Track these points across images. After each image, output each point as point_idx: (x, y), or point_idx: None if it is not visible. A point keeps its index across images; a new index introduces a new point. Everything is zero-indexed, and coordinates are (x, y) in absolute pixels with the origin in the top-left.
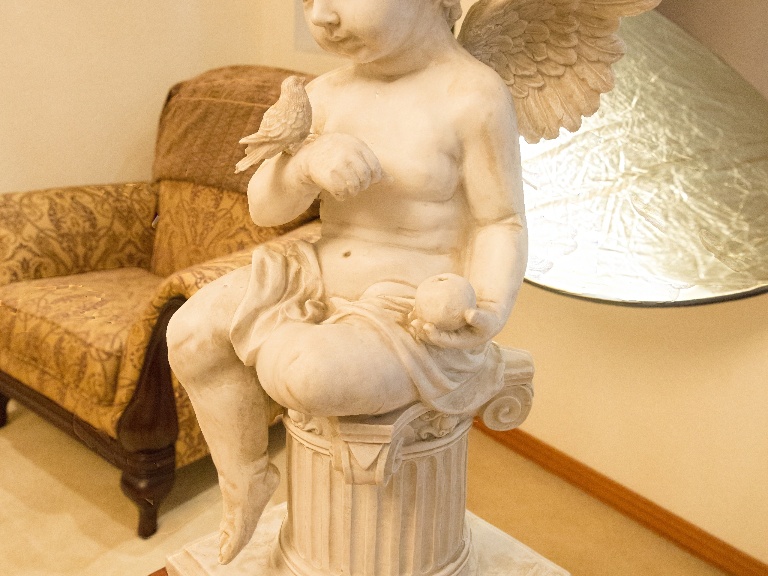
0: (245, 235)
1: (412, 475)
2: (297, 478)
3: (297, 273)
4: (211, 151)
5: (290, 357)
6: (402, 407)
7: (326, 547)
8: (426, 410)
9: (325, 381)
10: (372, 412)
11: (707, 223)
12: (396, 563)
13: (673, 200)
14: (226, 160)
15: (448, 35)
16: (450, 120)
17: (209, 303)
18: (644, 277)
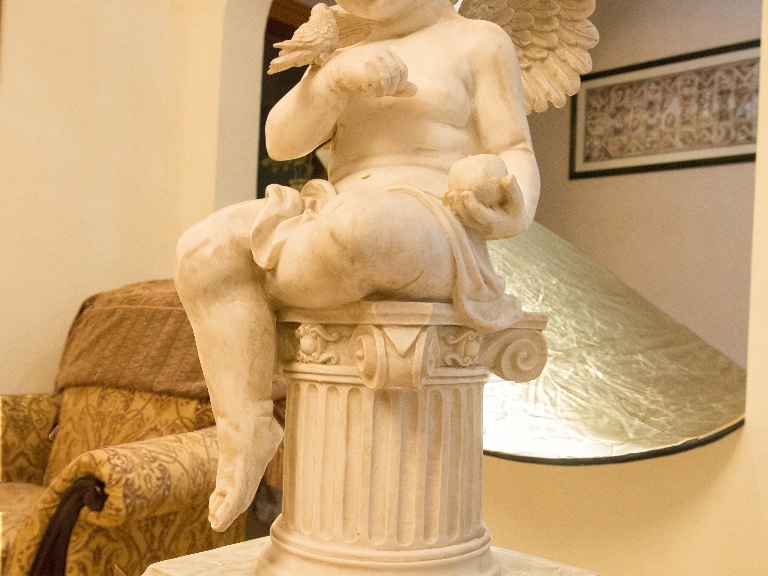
0: (156, 436)
1: (437, 408)
2: (305, 431)
3: (312, 203)
4: (124, 354)
5: (333, 206)
6: (436, 297)
7: (340, 506)
8: (454, 321)
9: (374, 219)
10: (414, 278)
11: (625, 395)
12: (421, 520)
13: (590, 377)
14: (140, 361)
15: (451, 4)
16: (464, 52)
17: (226, 214)
18: (576, 437)
